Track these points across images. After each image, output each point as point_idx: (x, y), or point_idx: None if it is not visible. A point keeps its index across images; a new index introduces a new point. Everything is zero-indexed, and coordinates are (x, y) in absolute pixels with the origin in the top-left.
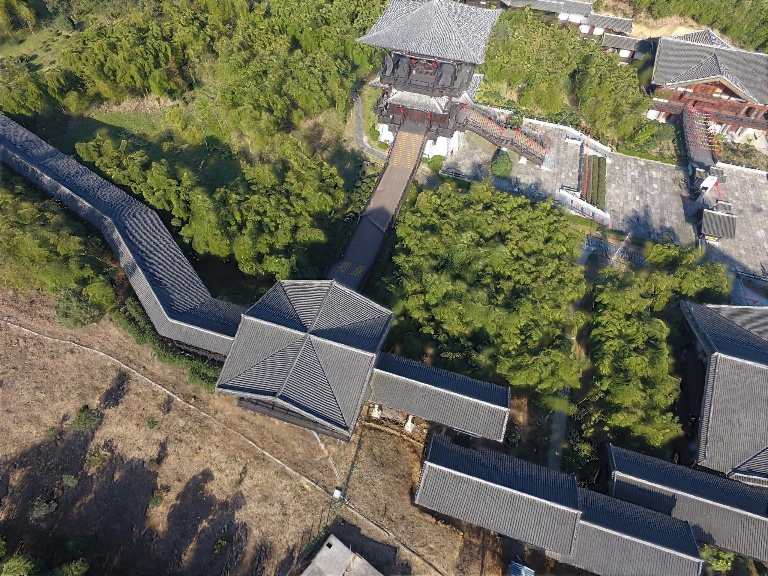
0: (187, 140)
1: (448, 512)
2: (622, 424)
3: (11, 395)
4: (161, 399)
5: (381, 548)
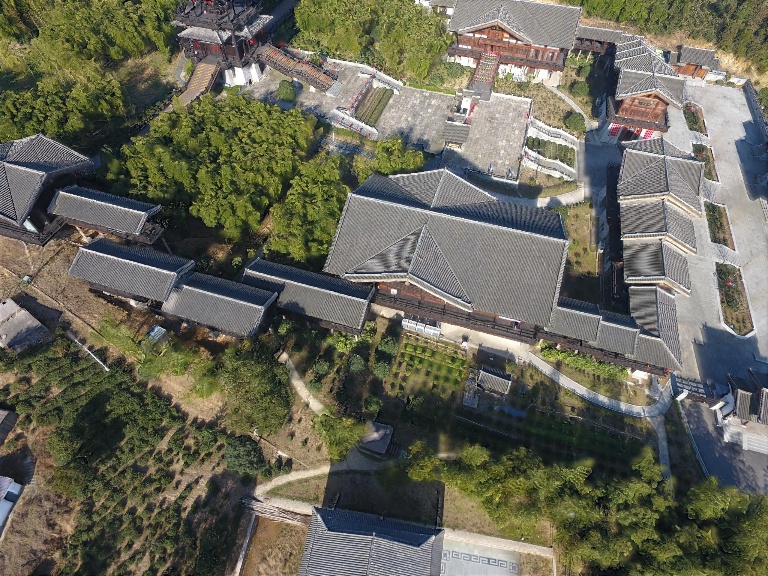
0: (10, 67)
1: (89, 279)
2: (281, 249)
3: None
4: None
5: (50, 311)
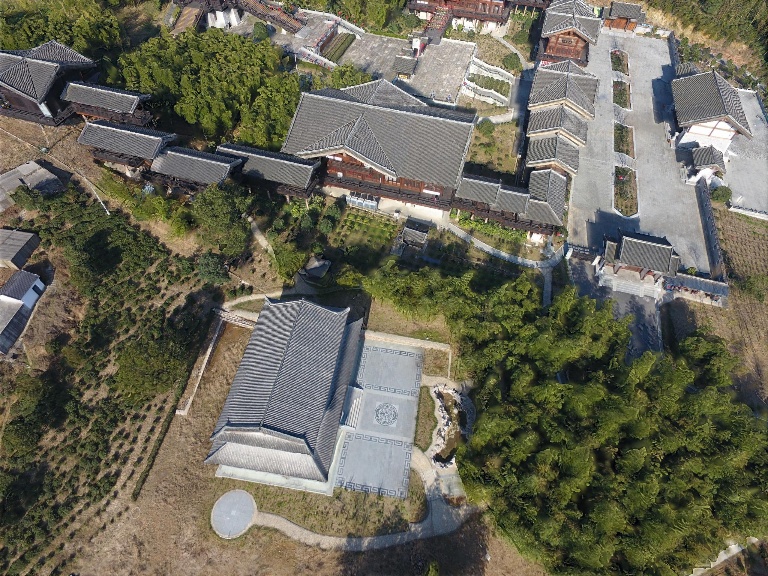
0: (23, 7)
1: (94, 145)
2: (248, 138)
3: None
4: None
5: (63, 172)
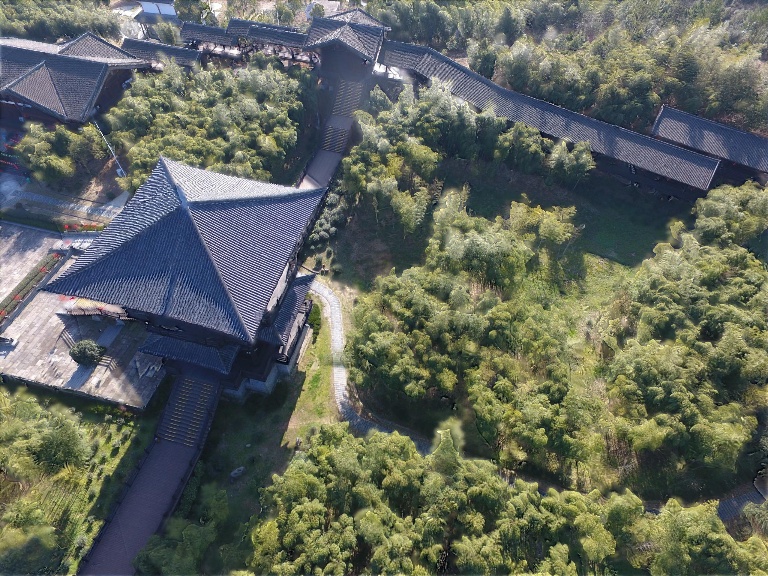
0: None
1: None
2: None
3: None
4: None
5: None
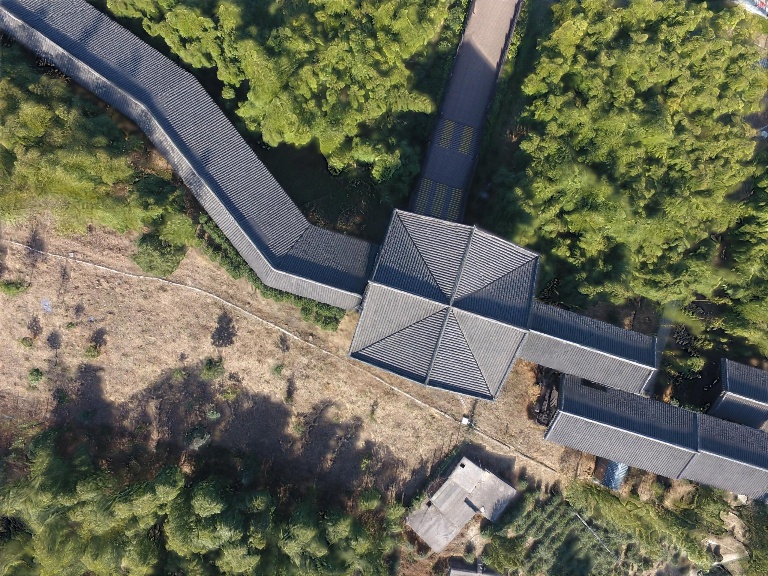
0: None
1: (574, 447)
2: None
3: (120, 341)
4: (277, 337)
5: (503, 459)
